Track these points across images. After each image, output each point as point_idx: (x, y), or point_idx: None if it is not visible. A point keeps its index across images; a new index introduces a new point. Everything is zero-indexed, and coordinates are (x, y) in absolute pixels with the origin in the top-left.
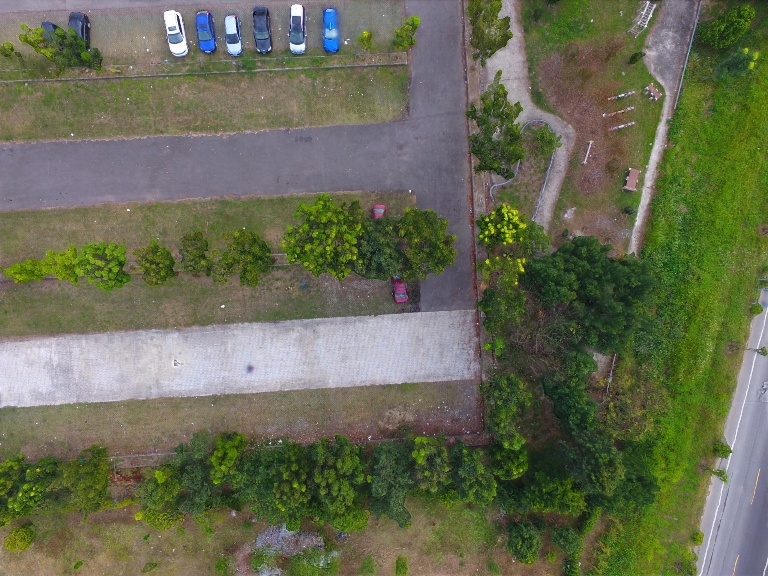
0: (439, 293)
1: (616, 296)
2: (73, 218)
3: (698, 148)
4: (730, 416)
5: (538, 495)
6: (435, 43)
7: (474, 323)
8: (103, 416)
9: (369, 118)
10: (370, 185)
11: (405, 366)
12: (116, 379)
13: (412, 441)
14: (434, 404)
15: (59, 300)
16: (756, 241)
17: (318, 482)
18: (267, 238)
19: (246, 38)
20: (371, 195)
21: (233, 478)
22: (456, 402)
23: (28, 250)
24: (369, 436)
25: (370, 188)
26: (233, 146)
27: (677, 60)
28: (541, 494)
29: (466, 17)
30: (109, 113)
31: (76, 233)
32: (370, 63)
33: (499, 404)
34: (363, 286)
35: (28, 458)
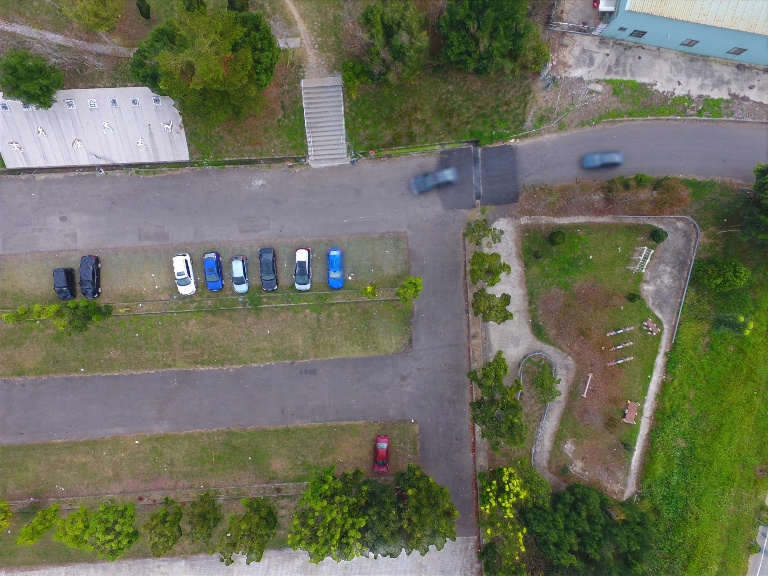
0: None
1: (615, 553)
2: (83, 450)
3: (696, 384)
4: None
5: None
6: (437, 278)
7: (476, 549)
8: None
9: (372, 350)
10: (373, 415)
11: None
12: None
13: None
14: None
15: None
16: (754, 482)
17: None
18: (272, 468)
19: (252, 274)
20: (374, 425)
21: None
22: None
23: (38, 482)
24: None
25: (373, 418)
26: (239, 379)
27: (675, 294)
28: None
29: (467, 253)
30: (118, 348)
31: (85, 465)
32: (373, 298)
33: None
34: None
35: None
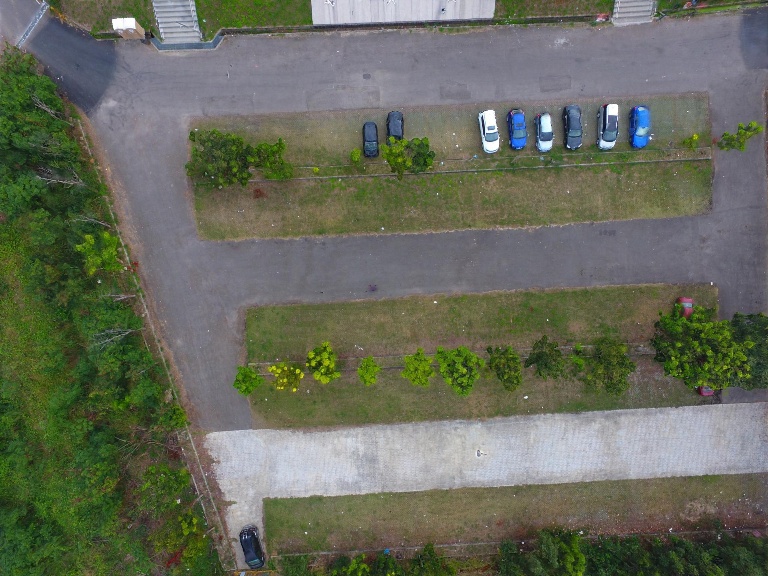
0: None
1: None
2: (381, 310)
3: None
4: None
5: None
6: None
7: None
8: (407, 506)
9: (672, 212)
10: (672, 278)
11: (706, 458)
12: (420, 469)
13: (767, 549)
14: (735, 496)
15: (366, 391)
16: None
17: None
18: (570, 330)
19: None
20: (673, 287)
21: None
22: (757, 495)
23: (337, 341)
24: (670, 528)
25: (672, 281)
26: (538, 239)
27: None
28: None
29: None
30: (419, 207)
31: (384, 325)
32: (675, 158)
33: None
34: (664, 378)
35: (334, 547)
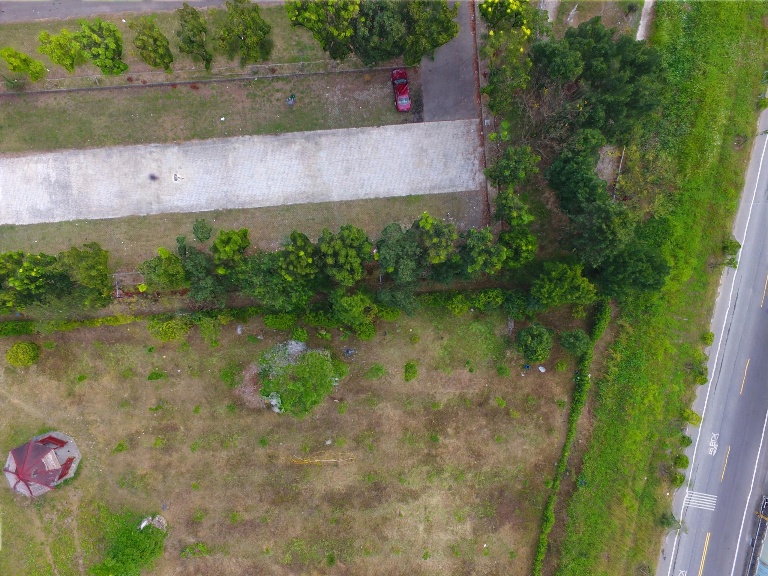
0: (442, 102)
1: None
2: (67, 29)
3: None
4: (738, 217)
5: None
6: None
7: (478, 133)
8: (103, 233)
9: None
10: None
11: (409, 178)
12: (116, 195)
13: None
14: (439, 216)
15: (55, 114)
16: (762, 32)
17: (325, 251)
18: (266, 48)
19: None
20: None
21: (238, 267)
22: (462, 213)
23: None
24: (374, 250)
25: None
26: None
27: None
28: (550, 281)
29: None
30: None
31: None
32: None
33: (506, 175)
34: (365, 97)
35: None
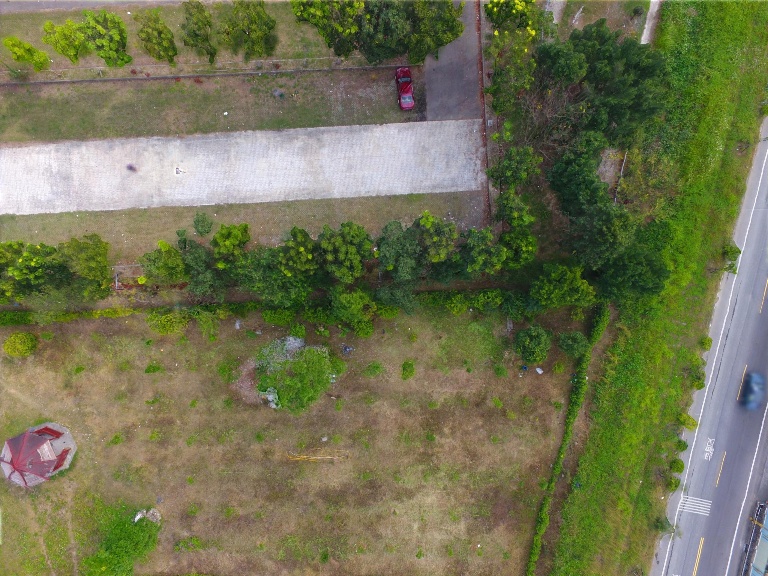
0: (445, 102)
1: None
2: (72, 20)
3: None
4: (739, 223)
5: (547, 283)
6: None
7: (481, 133)
8: (104, 225)
9: None
10: None
11: (411, 176)
12: (117, 187)
13: (420, 218)
14: (440, 215)
15: (58, 105)
16: (766, 38)
17: (325, 247)
18: (270, 44)
19: None
20: None
21: (237, 262)
22: (463, 213)
23: None
24: (374, 247)
25: None
26: None
27: None
28: (550, 282)
29: None
30: None
31: None
32: None
33: (508, 175)
34: (368, 94)
35: None
